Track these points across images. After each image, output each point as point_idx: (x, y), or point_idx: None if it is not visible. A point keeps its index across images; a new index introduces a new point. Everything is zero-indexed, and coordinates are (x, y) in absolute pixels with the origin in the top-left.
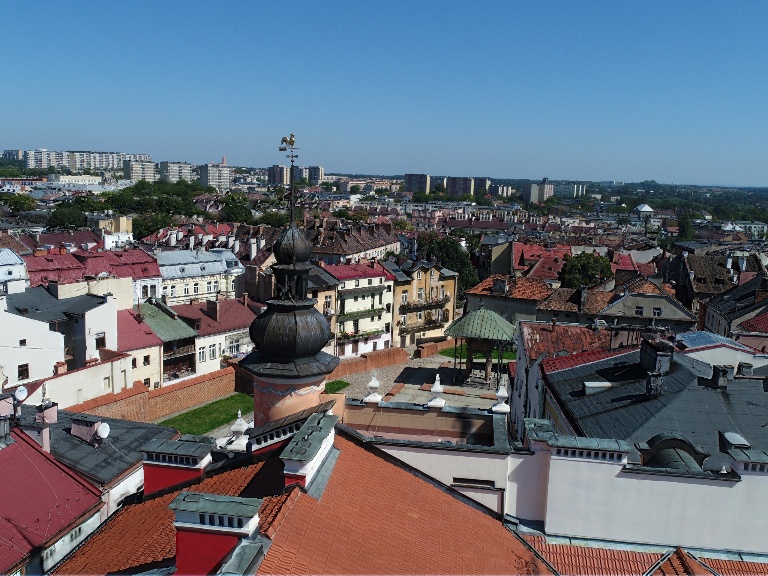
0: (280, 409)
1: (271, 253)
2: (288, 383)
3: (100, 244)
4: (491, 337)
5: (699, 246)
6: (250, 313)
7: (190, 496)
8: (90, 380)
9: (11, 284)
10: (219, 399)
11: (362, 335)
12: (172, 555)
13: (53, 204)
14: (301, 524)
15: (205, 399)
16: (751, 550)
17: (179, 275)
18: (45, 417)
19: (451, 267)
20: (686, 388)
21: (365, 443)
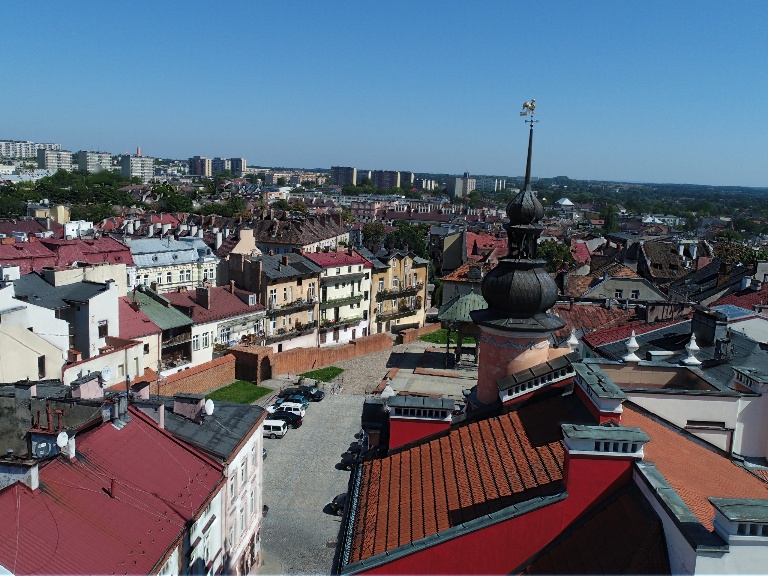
0: (520, 362)
1: (238, 242)
2: (530, 337)
3: (58, 233)
4: None
5: (631, 237)
6: (238, 301)
7: (578, 426)
8: None
9: (6, 270)
10: (222, 387)
11: (343, 322)
12: (521, 489)
13: None
14: None
15: (209, 387)
16: None
17: (152, 264)
18: (141, 396)
19: None
20: (752, 353)
21: None
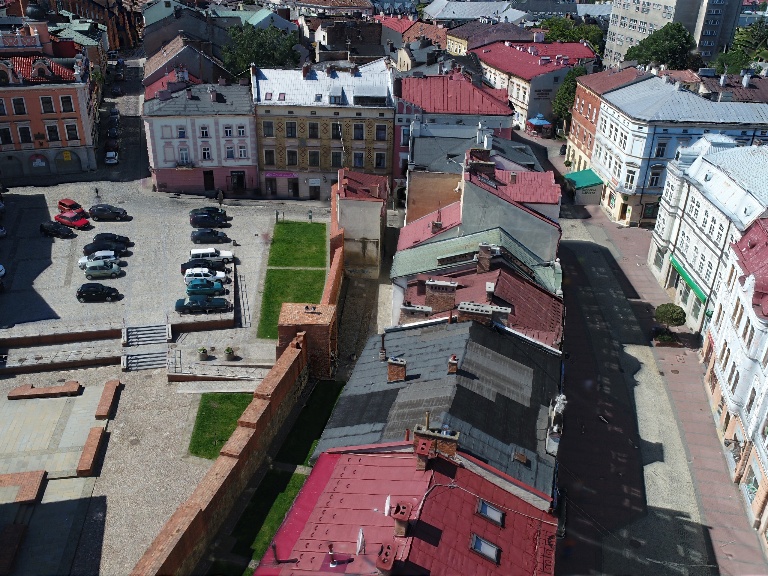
0: None
1: None
2: None
3: None
4: None
5: None
6: None
7: None
8: None
9: None
10: None
11: None
12: None
13: None
14: None
15: None
16: None
17: None
18: None
19: None
20: None
21: None
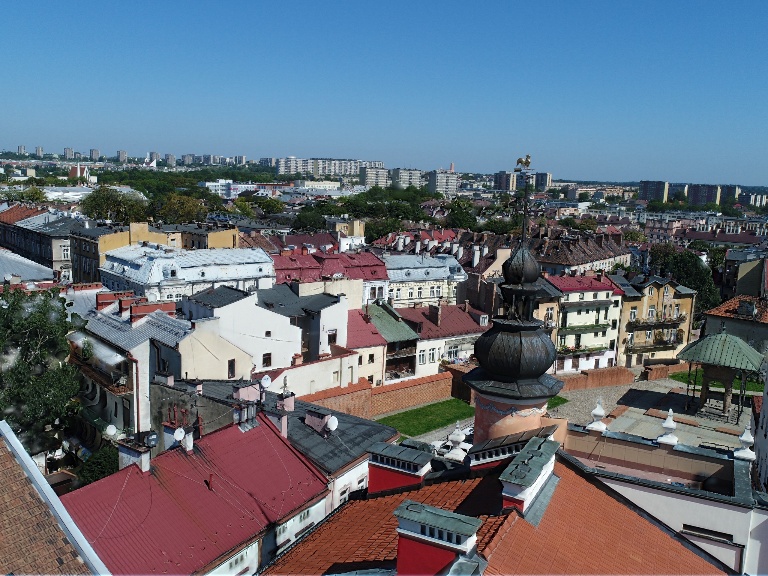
0: (500, 428)
1: (494, 261)
2: (510, 403)
3: (336, 246)
4: (733, 365)
5: None
6: (470, 320)
7: (413, 506)
8: (322, 373)
9: (261, 281)
10: (436, 402)
11: (584, 350)
12: (392, 557)
13: (298, 207)
14: (517, 549)
15: (423, 401)
16: None
17: (405, 279)
18: (284, 405)
19: (688, 284)
20: None
21: (586, 473)
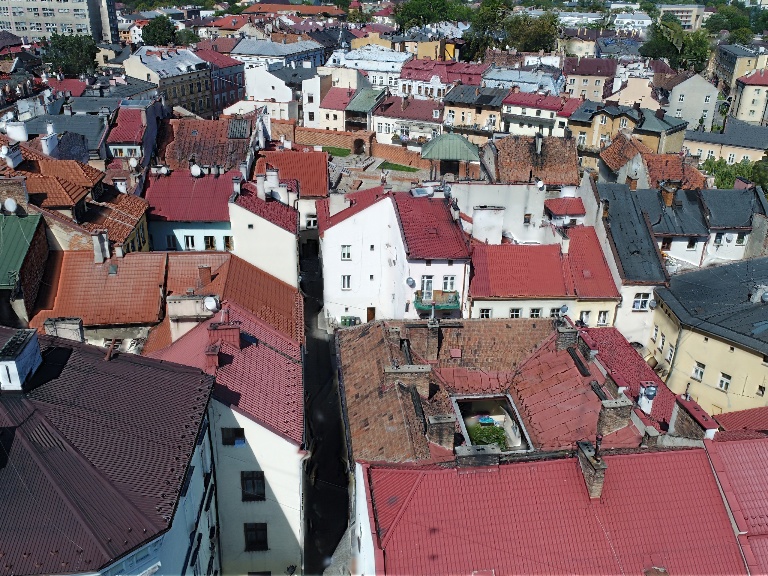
0: None
1: (623, 89)
2: None
3: None
4: None
5: None
6: None
7: None
8: None
9: (305, 63)
10: None
11: None
12: None
13: None
14: None
15: (334, 145)
16: None
17: None
18: (110, 82)
19: None
20: None
21: None
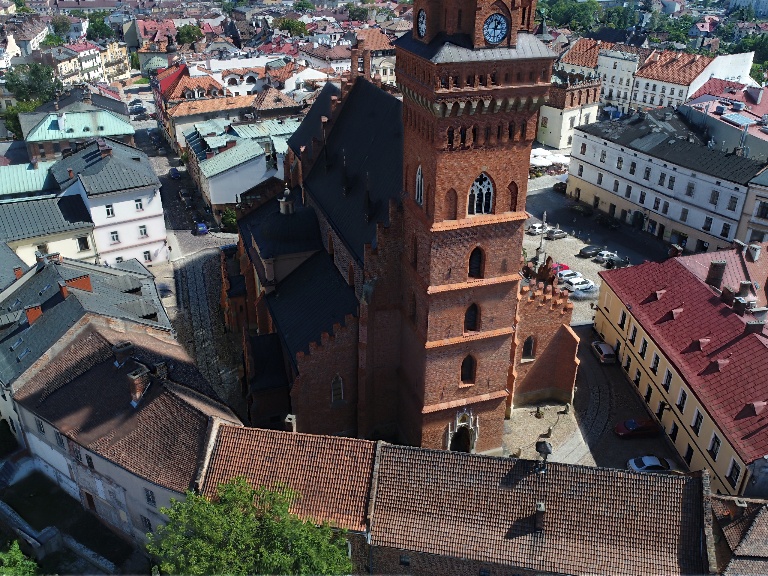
0: None
1: (7, 43)
2: None
3: None
4: None
5: (248, 10)
6: None
7: None
8: None
9: None
10: None
11: None
12: None
13: None
14: None
15: None
16: (235, 68)
17: None
18: None
19: None
20: None
21: None
